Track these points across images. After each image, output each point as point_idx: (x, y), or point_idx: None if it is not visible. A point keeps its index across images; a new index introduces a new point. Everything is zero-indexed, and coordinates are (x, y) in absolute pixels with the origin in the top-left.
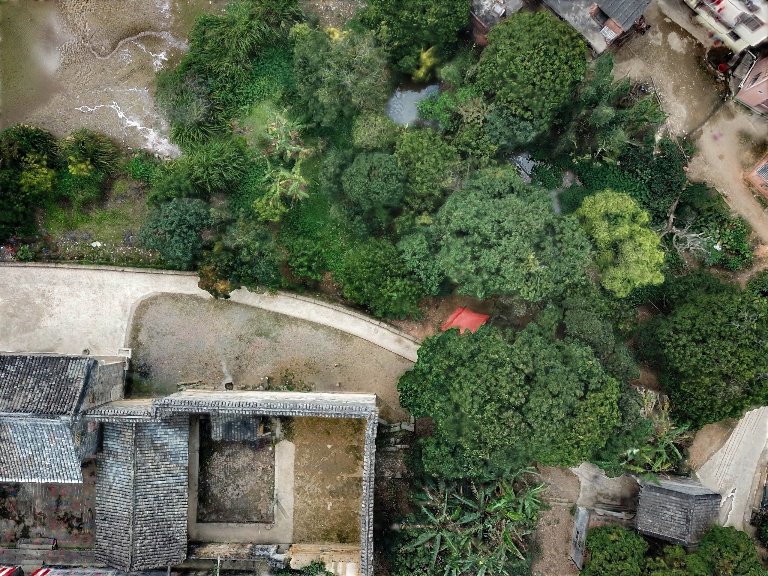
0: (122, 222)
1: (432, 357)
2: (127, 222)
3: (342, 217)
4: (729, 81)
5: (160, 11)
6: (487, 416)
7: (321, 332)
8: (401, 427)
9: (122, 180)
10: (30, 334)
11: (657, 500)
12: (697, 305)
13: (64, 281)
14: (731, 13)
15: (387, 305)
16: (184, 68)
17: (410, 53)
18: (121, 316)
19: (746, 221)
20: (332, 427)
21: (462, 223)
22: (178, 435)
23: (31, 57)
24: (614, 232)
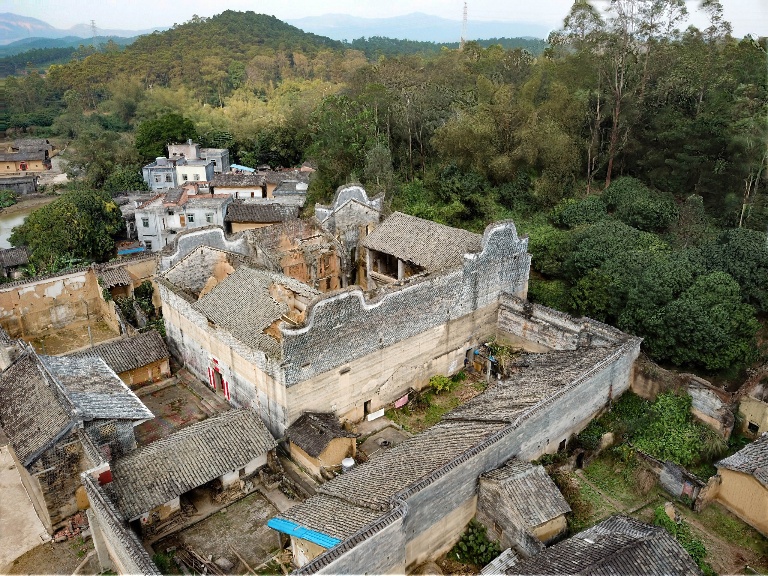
0: None
1: None
2: None
3: None
4: None
5: None
6: None
7: None
8: None
9: None
10: (7, 507)
11: (8, 260)
12: None
13: None
14: None
15: None
16: None
17: None
18: None
19: None
20: None
21: None
22: None
23: None
24: None
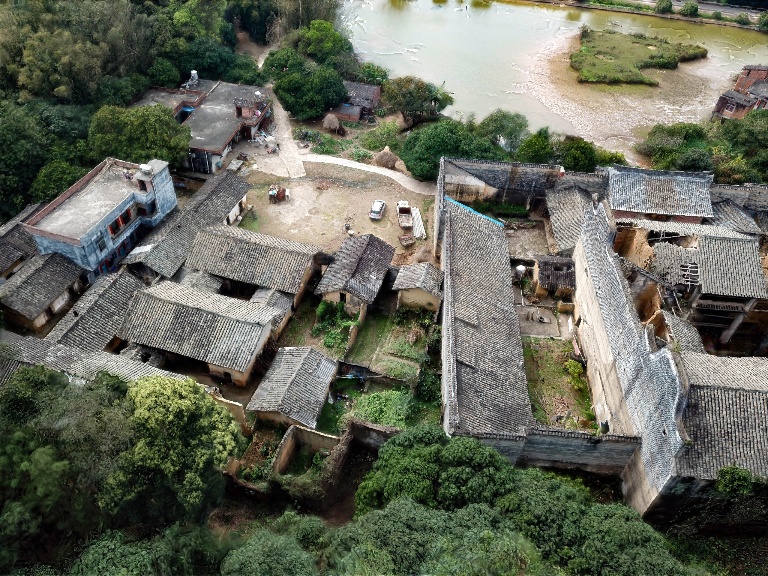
0: None
1: None
2: None
3: None
4: None
5: (625, 131)
6: None
7: None
8: None
9: None
10: None
11: None
12: None
13: None
14: None
15: None
16: None
17: None
18: None
19: None
20: None
21: None
22: None
23: None
24: None
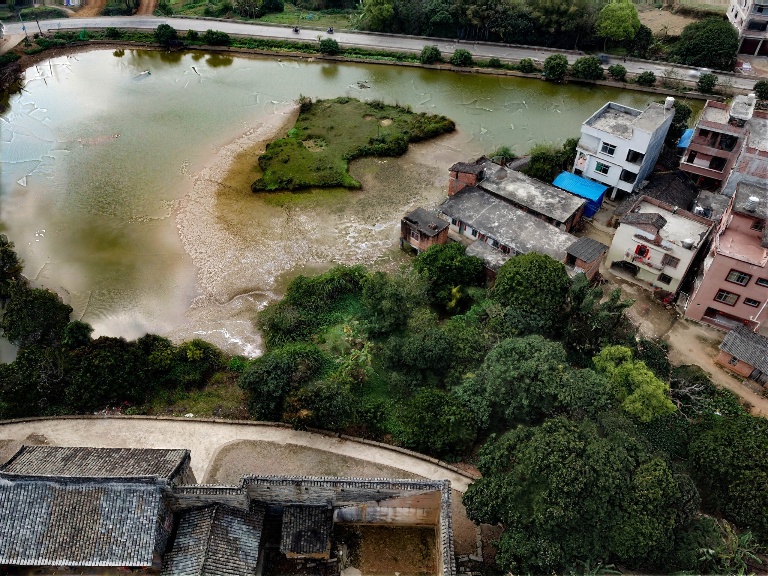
0: (215, 399)
1: (493, 450)
2: (219, 399)
3: (401, 381)
4: (676, 308)
5: (267, 281)
6: (552, 462)
7: (385, 472)
8: (469, 557)
9: (221, 372)
10: None
11: None
12: (714, 431)
13: (160, 430)
14: (657, 260)
15: (445, 436)
16: (282, 303)
17: (445, 289)
18: (204, 458)
19: (731, 390)
20: (399, 553)
21: (501, 350)
22: (251, 533)
23: (170, 305)
24: (622, 369)
